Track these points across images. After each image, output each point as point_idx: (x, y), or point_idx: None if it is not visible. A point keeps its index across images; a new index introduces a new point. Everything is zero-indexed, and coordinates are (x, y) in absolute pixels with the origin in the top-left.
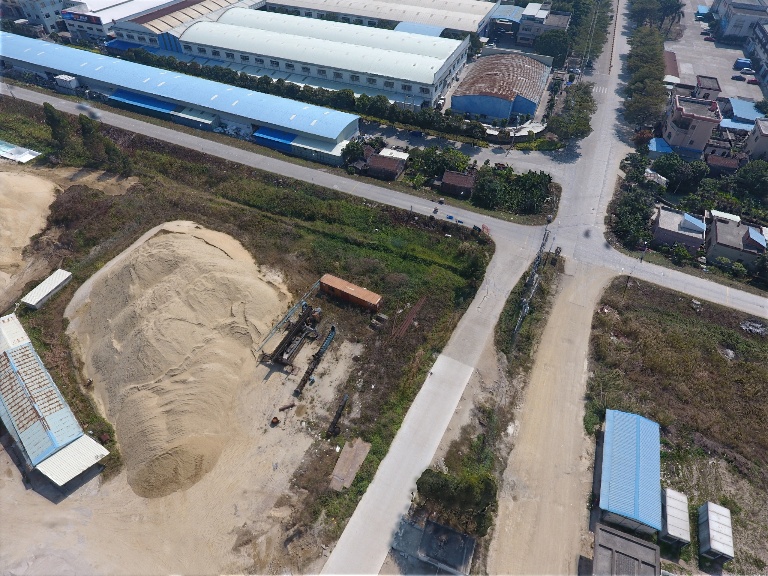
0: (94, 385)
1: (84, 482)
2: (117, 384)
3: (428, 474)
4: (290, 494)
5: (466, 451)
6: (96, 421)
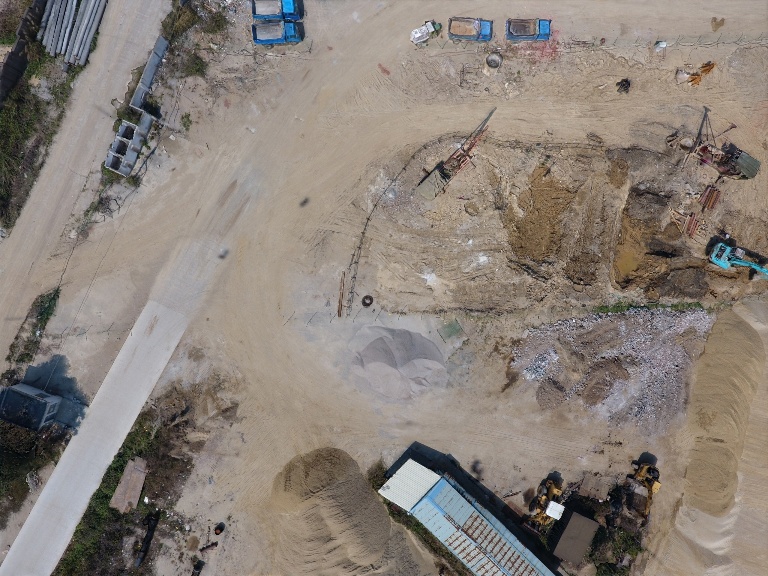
0: (436, 570)
1: (399, 462)
2: (402, 572)
3: (5, 477)
4: (191, 453)
5: (4, 500)
6: (414, 526)
